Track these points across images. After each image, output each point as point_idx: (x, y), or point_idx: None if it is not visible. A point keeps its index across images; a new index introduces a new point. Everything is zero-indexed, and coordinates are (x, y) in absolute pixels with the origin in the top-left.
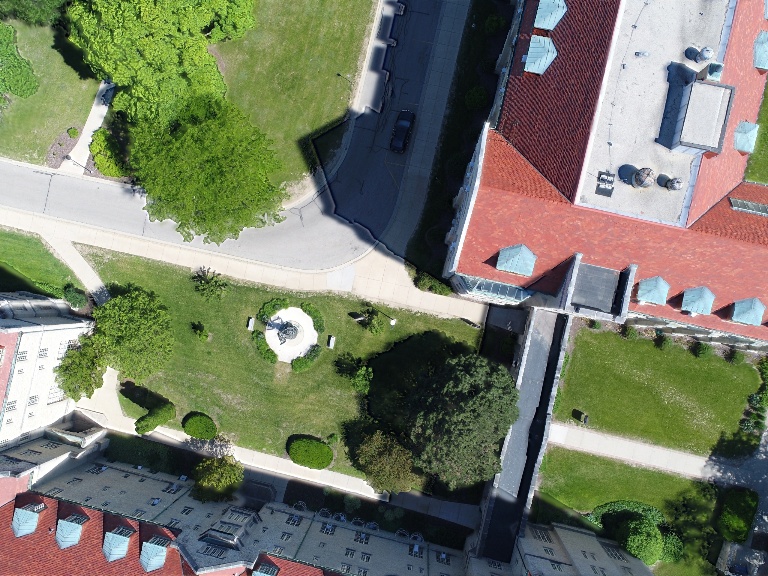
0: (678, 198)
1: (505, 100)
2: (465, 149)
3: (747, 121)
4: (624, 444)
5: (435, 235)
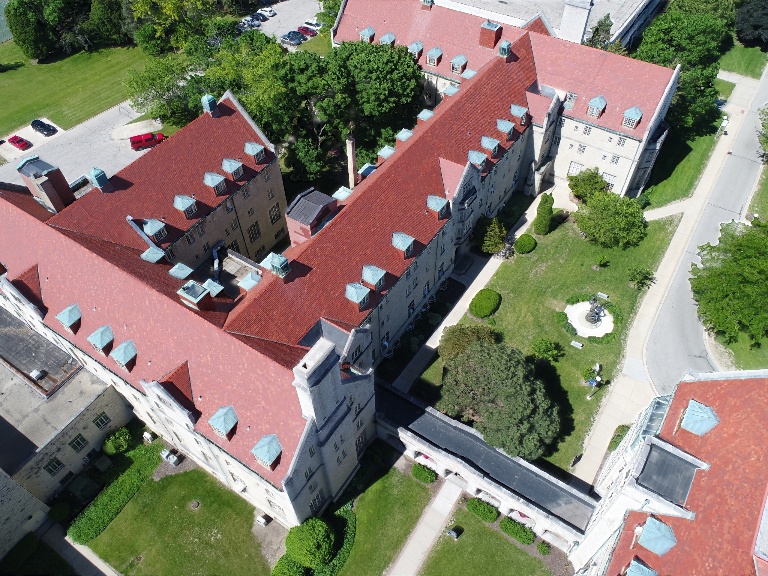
0: None
1: None
2: None
3: None
4: (411, 570)
5: None
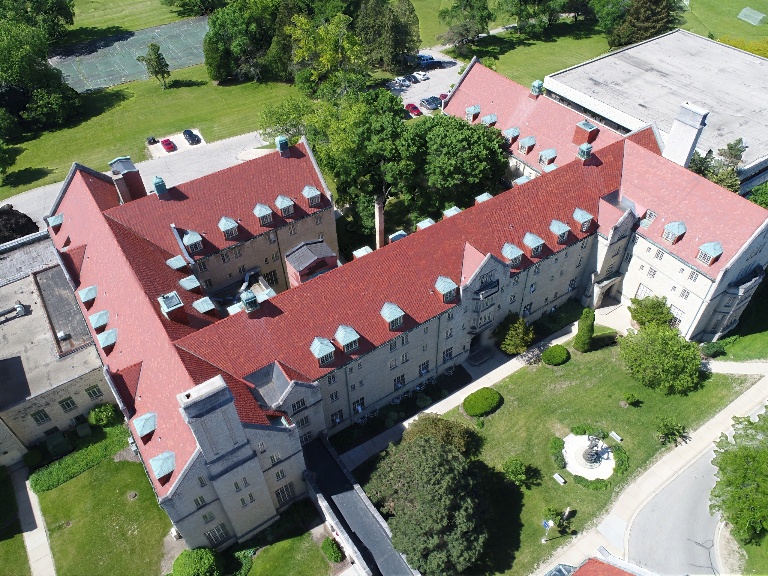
0: None
1: None
2: None
3: None
4: None
5: None
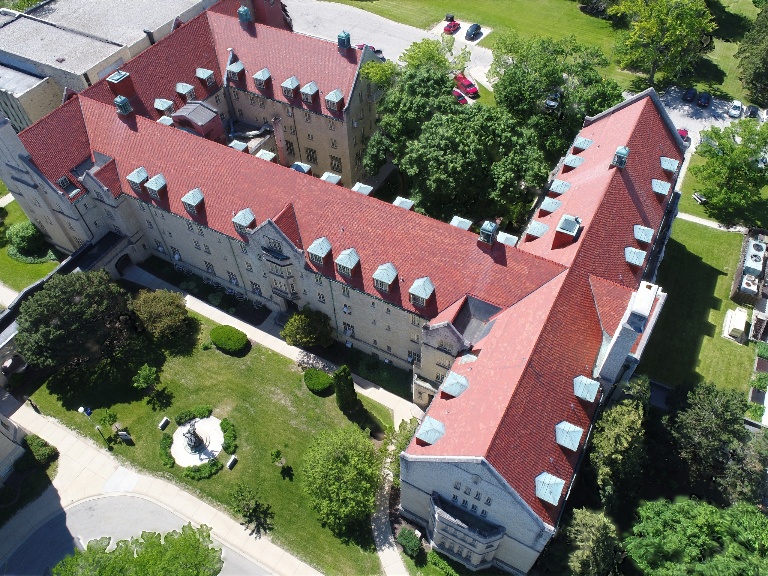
0: None
1: None
2: None
3: None
4: None
5: (2, 493)
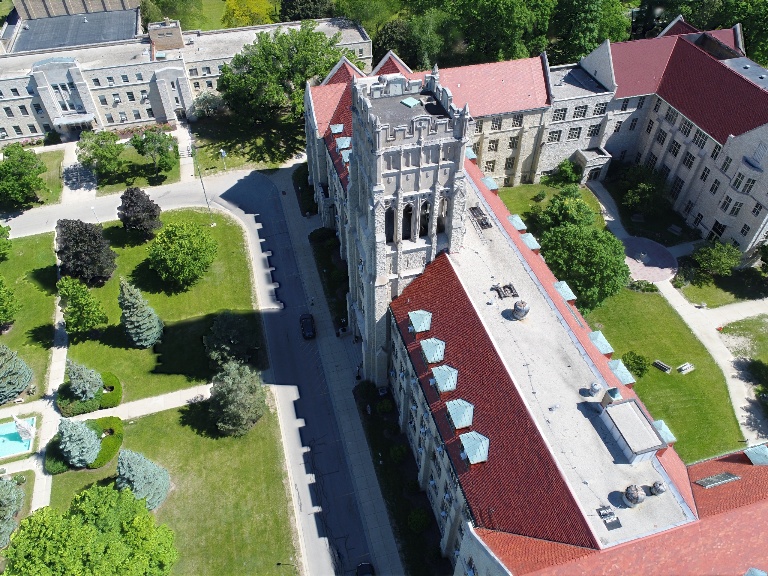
0: (669, 499)
1: (467, 497)
2: (435, 573)
3: (652, 422)
4: None
5: None
